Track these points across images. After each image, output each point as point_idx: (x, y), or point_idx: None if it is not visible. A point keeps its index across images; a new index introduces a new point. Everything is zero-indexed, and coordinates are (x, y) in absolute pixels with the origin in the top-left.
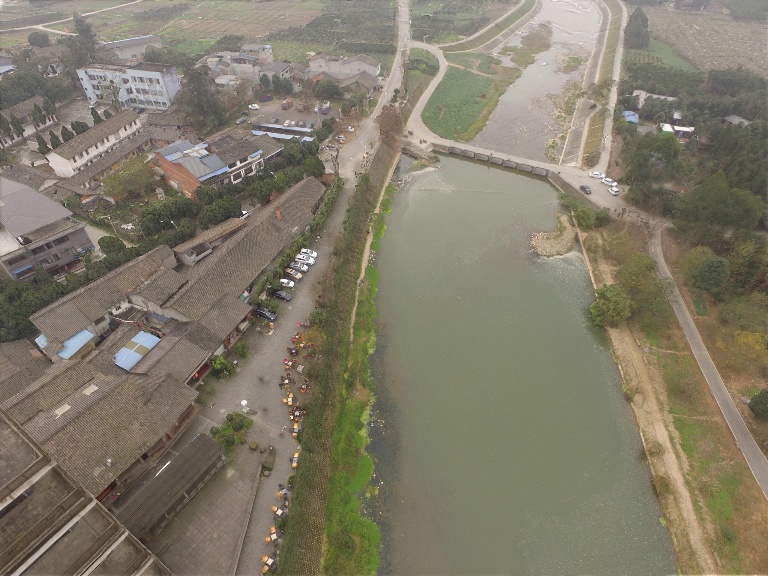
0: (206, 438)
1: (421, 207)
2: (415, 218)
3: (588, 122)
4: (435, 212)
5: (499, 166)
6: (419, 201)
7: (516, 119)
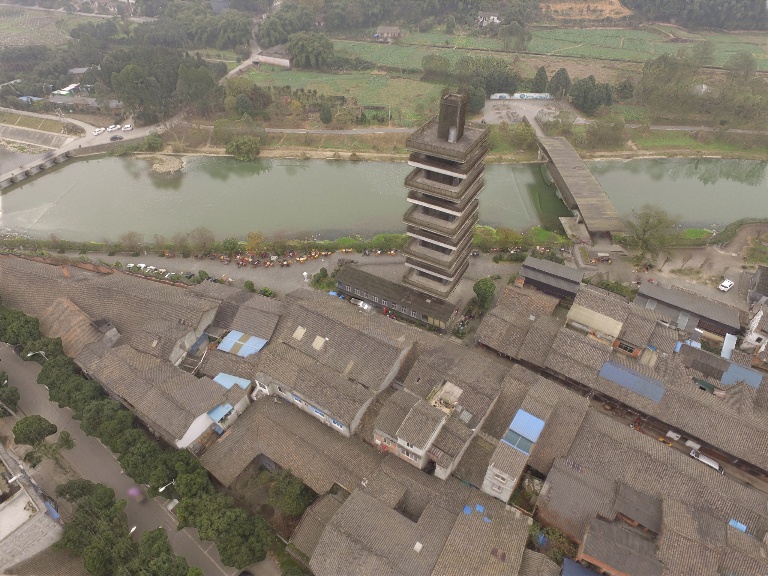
0: (339, 274)
1: (72, 221)
2: (90, 223)
3: (2, 124)
4: (86, 214)
5: (29, 179)
6: (59, 223)
7: None
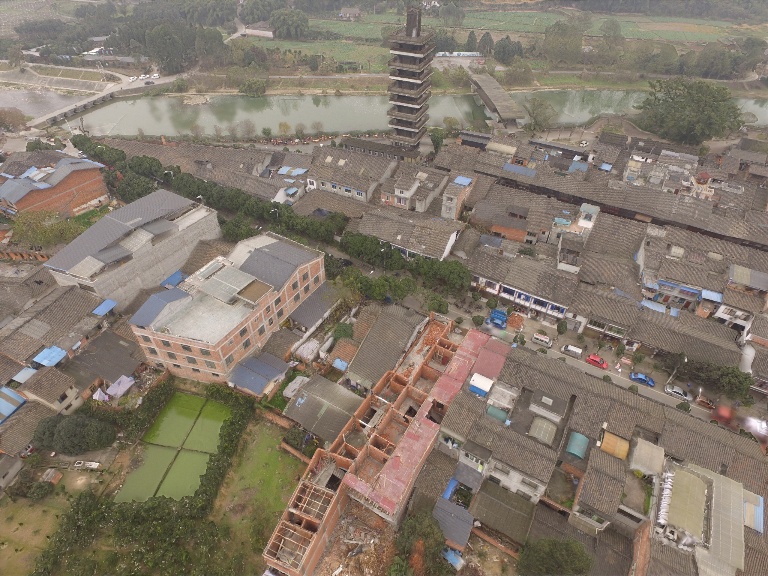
0: None
1: (137, 132)
2: (152, 132)
3: (46, 76)
4: (145, 128)
5: (87, 111)
6: (127, 133)
7: (4, 101)
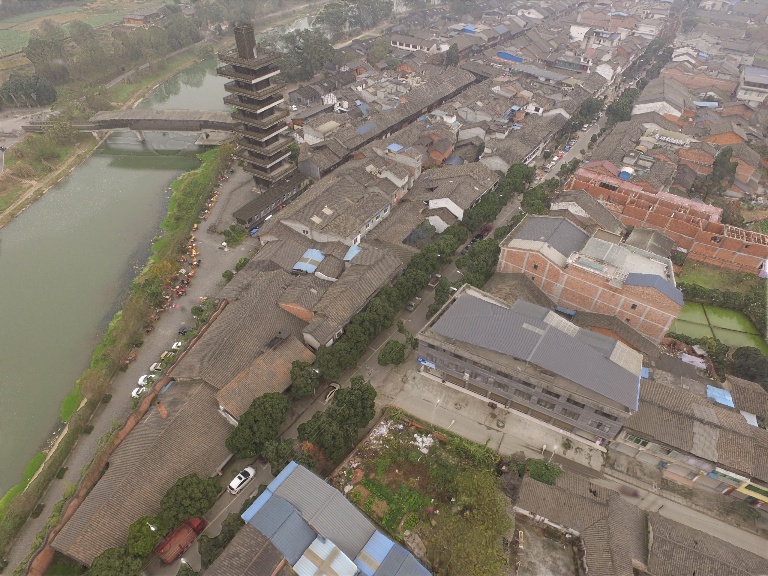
0: (242, 217)
1: None
2: None
3: None
4: None
5: None
6: None
7: None
